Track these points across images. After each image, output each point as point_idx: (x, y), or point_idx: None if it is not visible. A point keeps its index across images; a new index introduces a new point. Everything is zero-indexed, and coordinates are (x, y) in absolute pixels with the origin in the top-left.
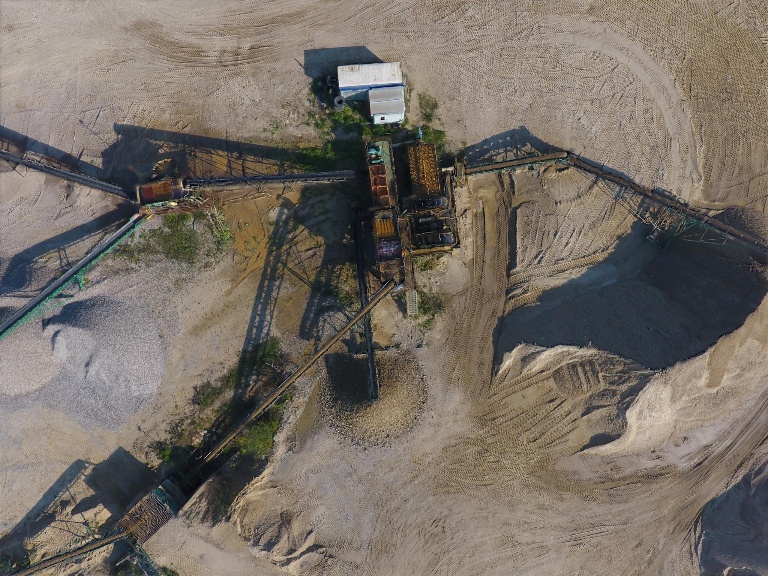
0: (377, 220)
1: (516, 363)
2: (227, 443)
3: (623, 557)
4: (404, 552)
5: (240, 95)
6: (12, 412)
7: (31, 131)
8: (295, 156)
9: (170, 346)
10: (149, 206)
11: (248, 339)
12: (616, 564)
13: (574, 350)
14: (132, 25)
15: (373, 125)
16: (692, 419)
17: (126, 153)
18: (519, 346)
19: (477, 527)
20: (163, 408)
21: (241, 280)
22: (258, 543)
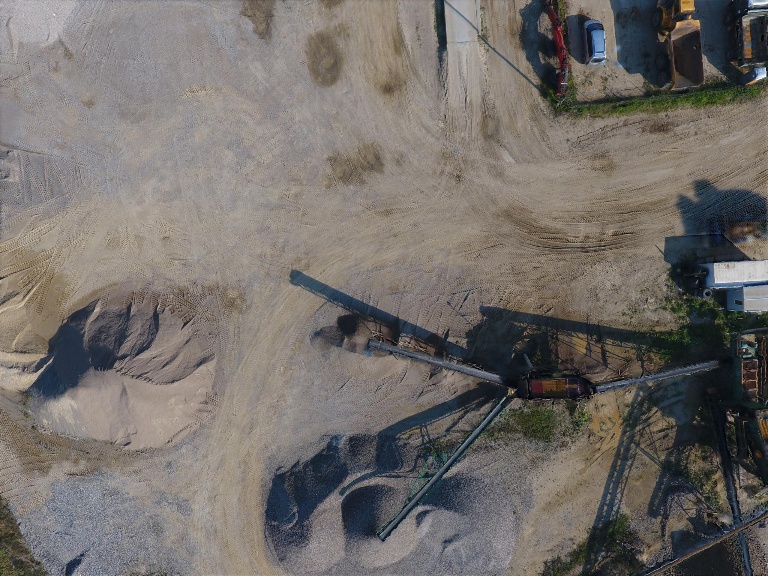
0: (760, 420)
1: None
2: None
3: None
4: None
5: (602, 280)
6: None
7: (402, 312)
8: (652, 340)
9: (523, 522)
10: None
11: (599, 516)
12: None
13: None
14: (503, 211)
15: (727, 311)
16: None
17: (490, 334)
18: None
19: None
20: None
21: (595, 459)
22: None
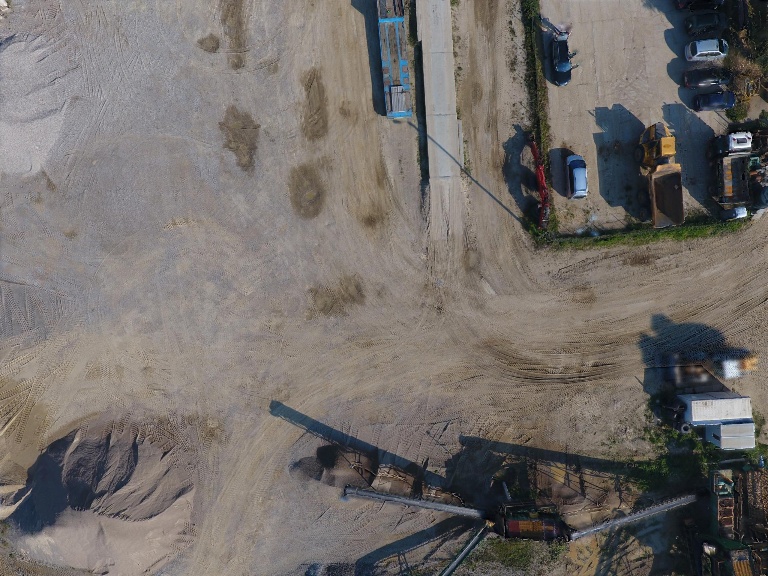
0: (734, 561)
1: None
2: None
3: None
4: None
5: (581, 410)
6: None
7: (381, 442)
8: (630, 470)
9: None
10: None
11: None
12: None
13: None
14: (484, 343)
15: (706, 441)
16: None
17: (469, 463)
18: None
19: None
20: None
21: None
22: None
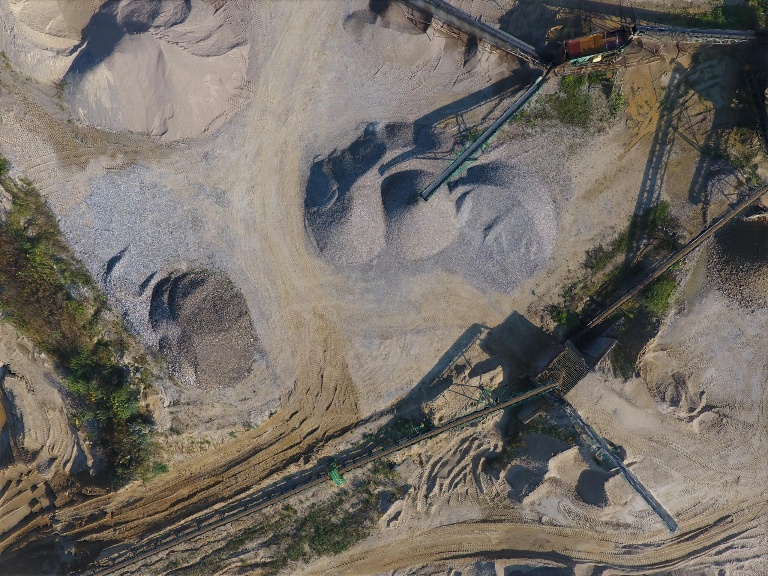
0: None
1: None
2: (618, 307)
3: None
4: None
5: None
6: (412, 276)
7: None
8: (686, 21)
9: (563, 211)
10: (569, 63)
11: (639, 203)
12: None
13: None
14: None
15: None
16: None
17: (522, 19)
18: None
19: None
20: (556, 272)
21: (633, 144)
22: (665, 399)
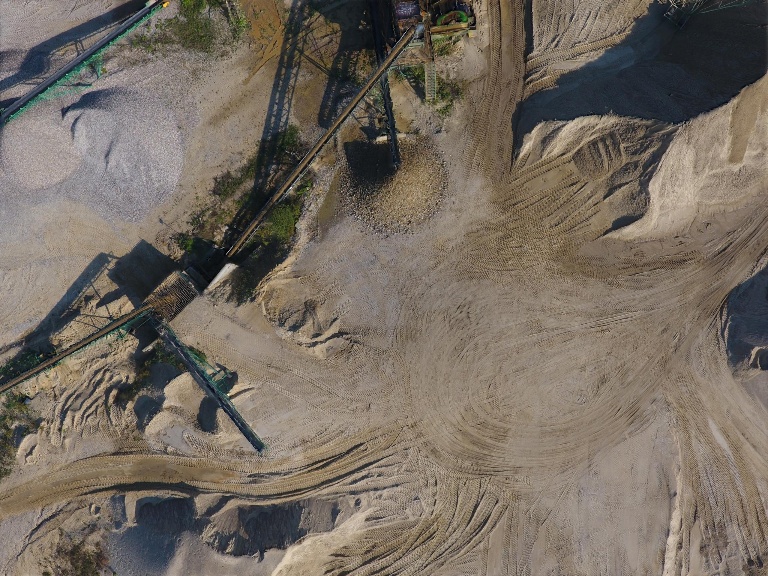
0: None
1: (536, 146)
2: (249, 234)
3: (649, 343)
4: (429, 338)
5: None
6: (34, 206)
7: None
8: None
9: (189, 137)
10: None
11: (267, 128)
12: (642, 350)
13: (595, 122)
14: None
15: None
16: (715, 202)
17: None
18: (539, 125)
19: (502, 313)
20: (184, 200)
21: (258, 68)
22: (284, 324)
